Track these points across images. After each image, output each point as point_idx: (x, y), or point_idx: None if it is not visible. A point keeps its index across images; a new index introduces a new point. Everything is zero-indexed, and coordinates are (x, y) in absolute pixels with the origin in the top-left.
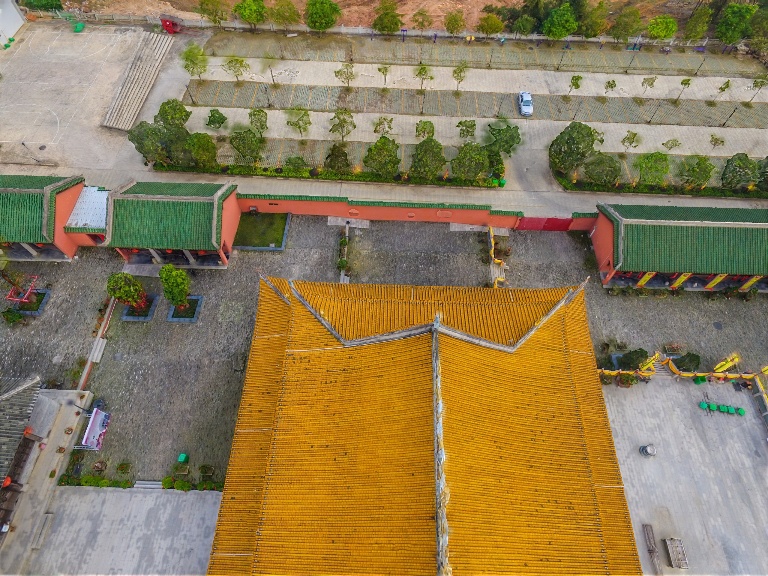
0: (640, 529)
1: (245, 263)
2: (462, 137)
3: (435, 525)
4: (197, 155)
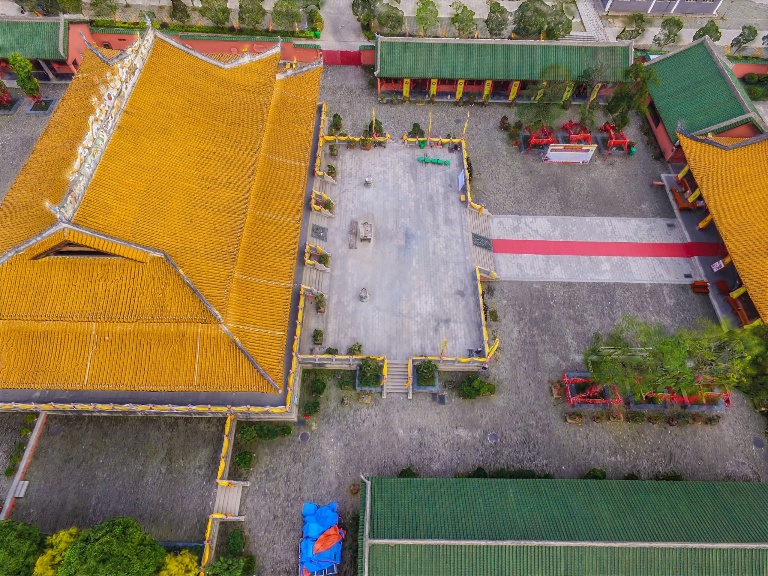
0: (349, 224)
1: None
2: None
3: None
4: (61, 3)
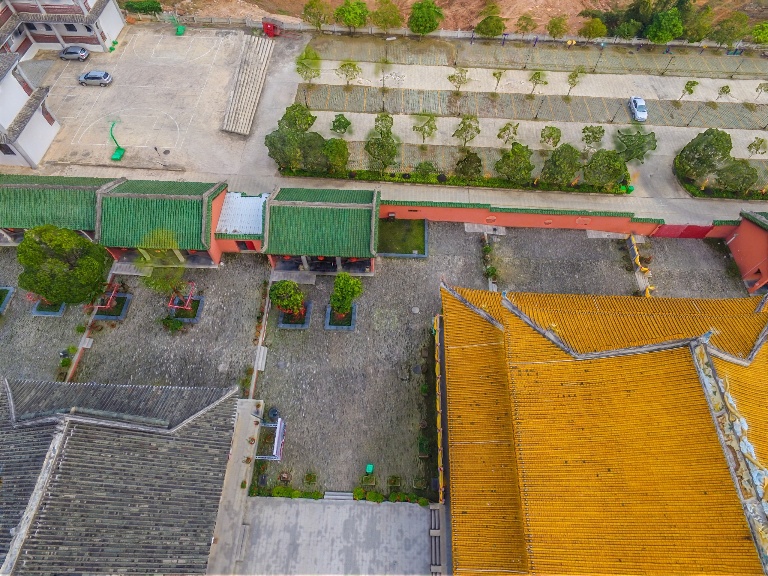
0: None
1: (390, 270)
2: (587, 143)
3: (754, 546)
4: (334, 161)
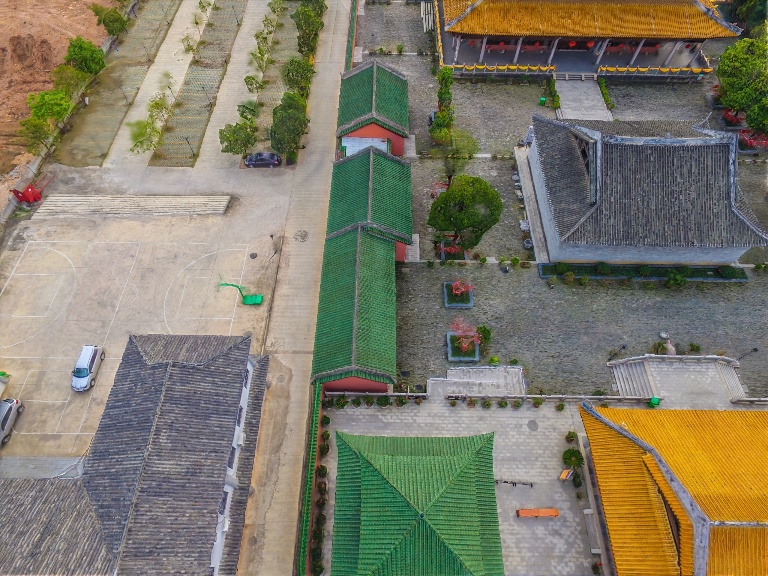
0: None
1: None
2: None
3: None
4: None
